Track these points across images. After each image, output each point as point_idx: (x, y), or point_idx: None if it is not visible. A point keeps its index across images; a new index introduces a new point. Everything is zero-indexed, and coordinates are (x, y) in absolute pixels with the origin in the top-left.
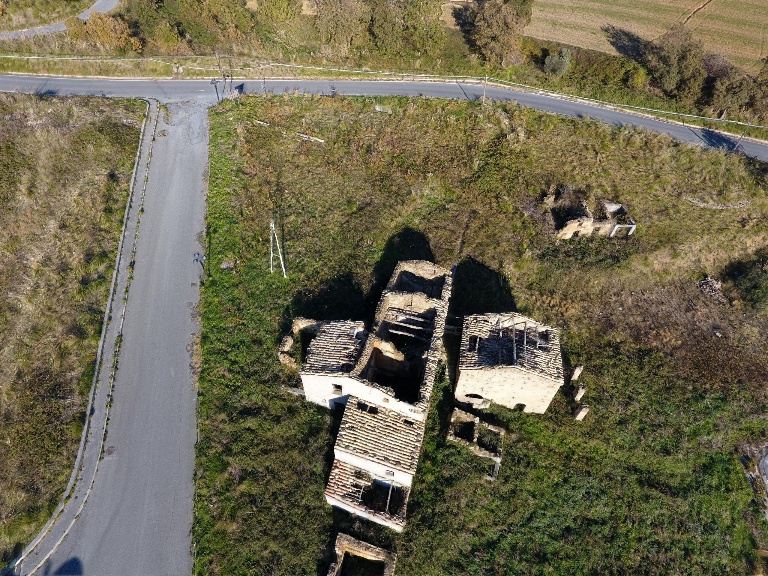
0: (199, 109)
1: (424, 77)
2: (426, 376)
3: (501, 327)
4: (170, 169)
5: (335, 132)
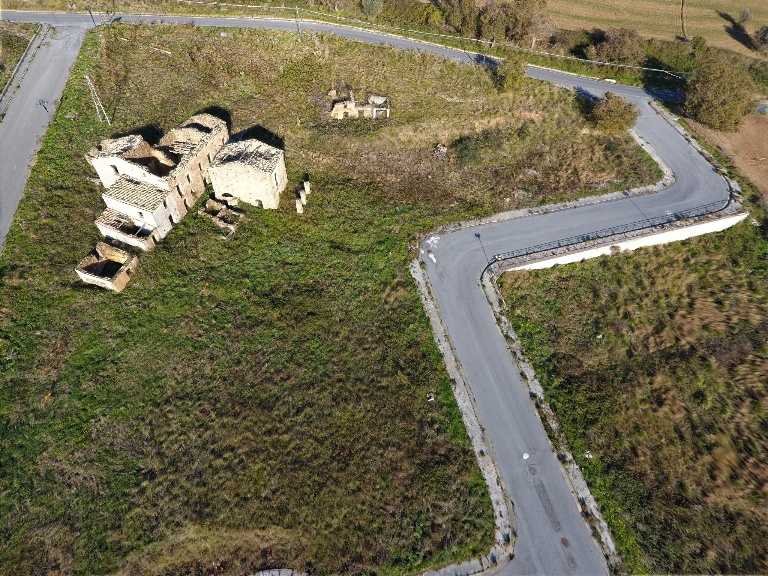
0: (80, 30)
1: (270, 16)
2: (177, 166)
3: (248, 151)
4: (46, 65)
5: (182, 48)
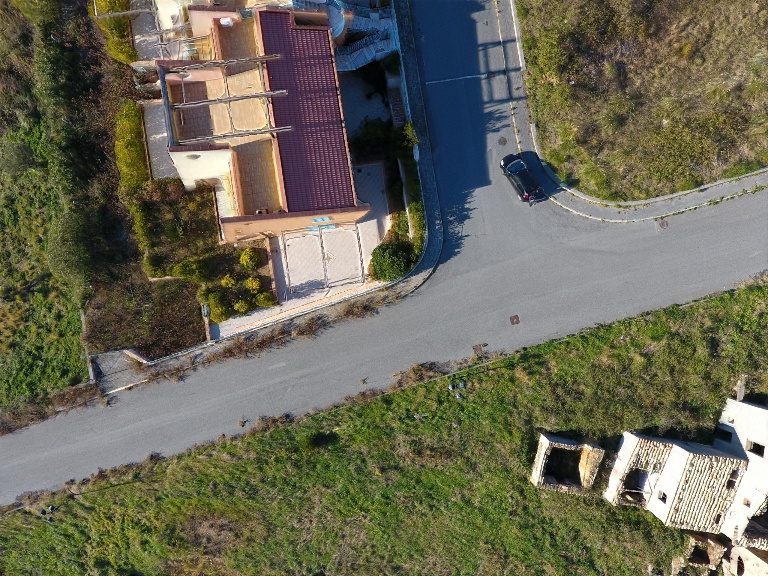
0: None
1: None
2: None
3: None
4: None
5: None
